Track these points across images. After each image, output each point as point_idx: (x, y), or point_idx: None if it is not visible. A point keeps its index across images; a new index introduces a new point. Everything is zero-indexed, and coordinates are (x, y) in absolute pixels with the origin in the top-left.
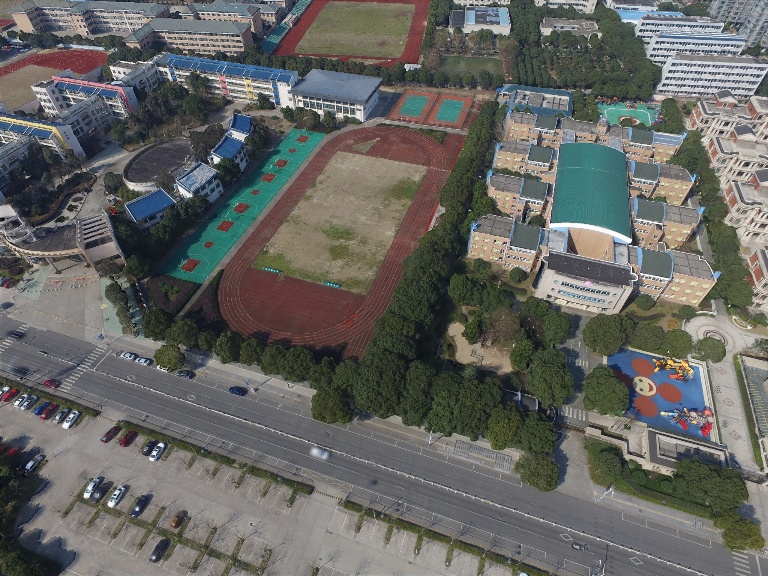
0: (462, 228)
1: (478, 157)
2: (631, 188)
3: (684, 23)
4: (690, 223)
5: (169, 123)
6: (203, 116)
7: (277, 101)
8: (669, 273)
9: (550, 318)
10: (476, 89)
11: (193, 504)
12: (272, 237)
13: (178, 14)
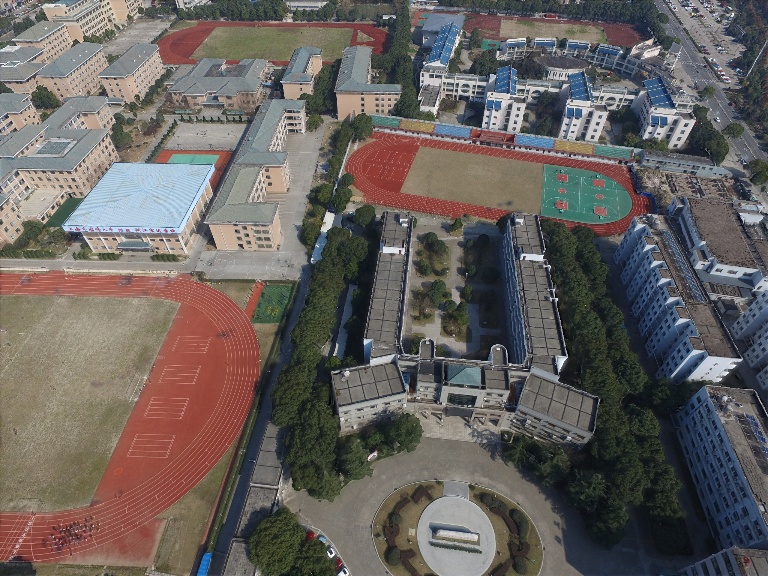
0: None
1: None
2: None
3: None
4: None
5: None
6: None
7: None
8: None
9: None
10: None
11: (707, 40)
12: None
13: None
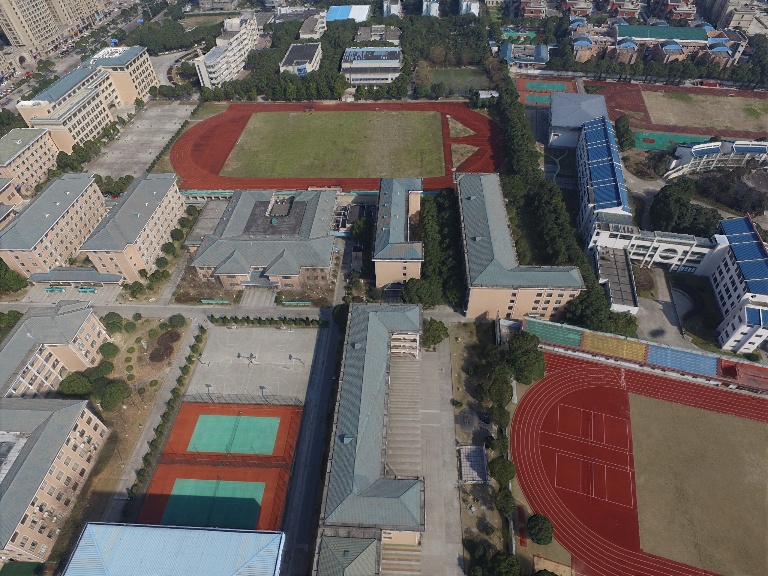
0: None
1: None
2: None
3: None
4: None
5: None
6: None
7: None
8: (711, 26)
9: (767, 49)
10: None
11: None
12: None
13: None
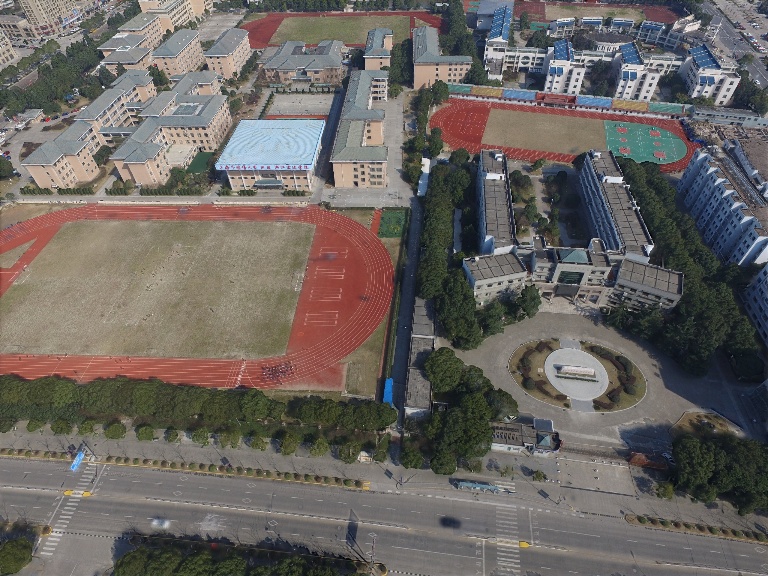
0: None
1: None
2: None
3: None
4: None
5: None
6: None
7: None
8: None
9: None
10: None
11: None
12: None
13: None
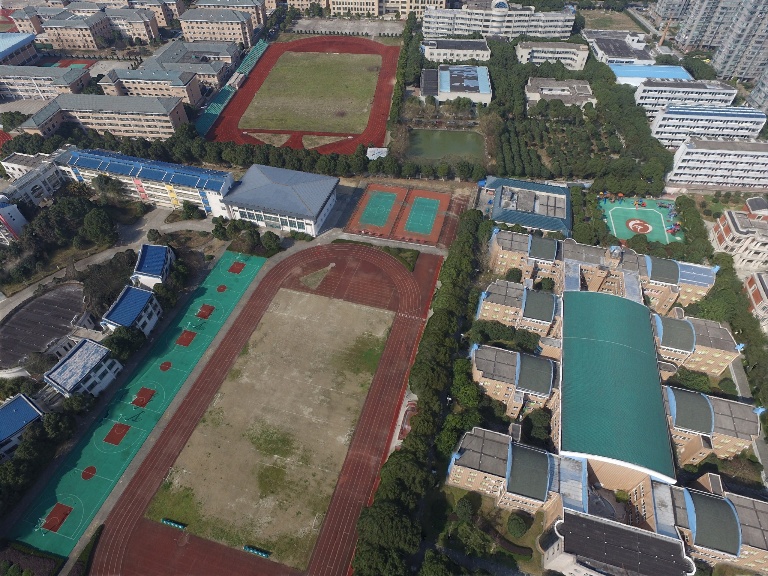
0: (439, 443)
1: (458, 308)
2: (661, 366)
3: (691, 90)
4: (748, 434)
5: (67, 246)
6: (109, 239)
7: (208, 209)
8: (736, 547)
9: None
10: (454, 180)
11: None
12: (180, 454)
13: (100, 78)
